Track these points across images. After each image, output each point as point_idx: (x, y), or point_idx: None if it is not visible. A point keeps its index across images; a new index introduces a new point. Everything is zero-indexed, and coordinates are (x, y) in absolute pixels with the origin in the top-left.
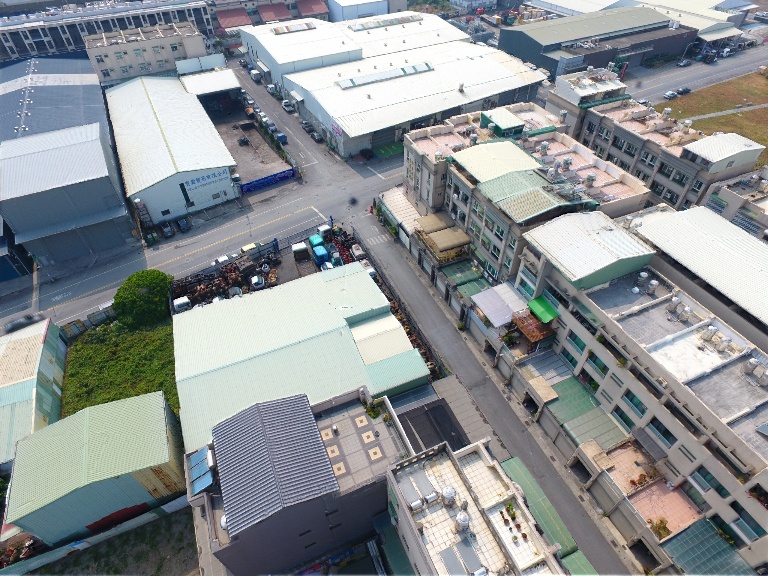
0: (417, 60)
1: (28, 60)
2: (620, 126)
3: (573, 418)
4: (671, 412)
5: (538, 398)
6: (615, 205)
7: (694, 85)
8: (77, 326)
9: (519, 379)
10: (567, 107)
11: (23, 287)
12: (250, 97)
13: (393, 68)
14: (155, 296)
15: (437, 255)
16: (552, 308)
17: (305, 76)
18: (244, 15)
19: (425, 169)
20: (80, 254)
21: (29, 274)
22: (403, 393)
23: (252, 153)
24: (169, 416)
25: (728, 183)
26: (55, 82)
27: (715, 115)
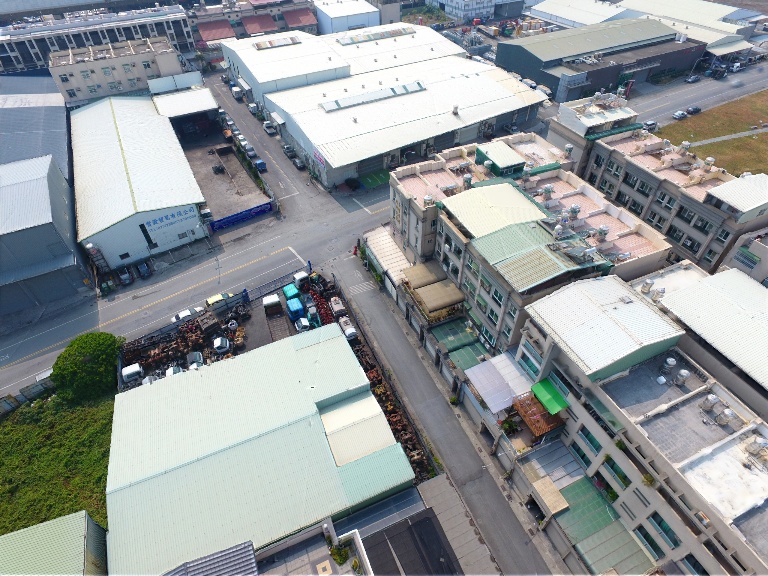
0: (409, 78)
1: None
2: (632, 162)
3: (587, 536)
4: (714, 555)
5: (544, 507)
6: (632, 264)
7: (704, 104)
8: (8, 402)
9: (521, 477)
10: (572, 137)
11: None
12: (229, 117)
13: (382, 87)
14: (100, 366)
15: (426, 314)
16: (560, 395)
17: (287, 96)
18: (227, 27)
19: (413, 214)
20: (24, 307)
21: None
22: (383, 500)
23: (227, 182)
24: (95, 539)
25: (759, 233)
26: (15, 104)
27: (729, 138)
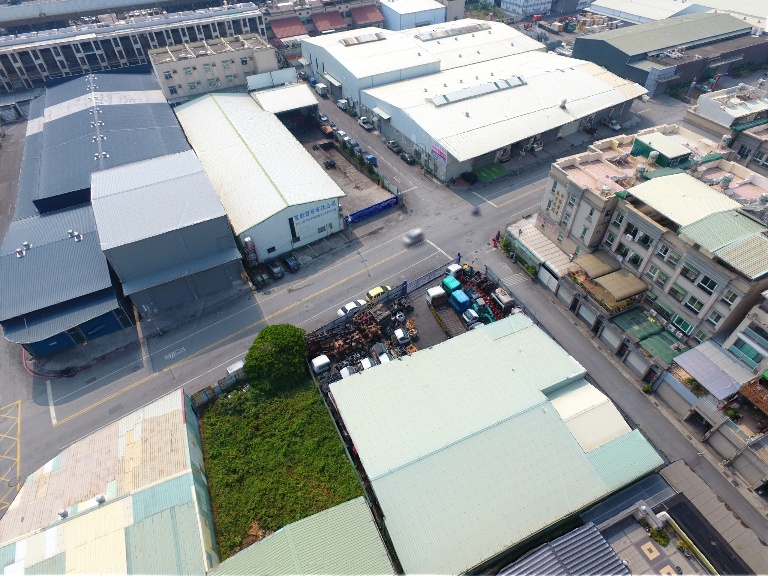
0: (503, 73)
1: (86, 76)
2: None
3: None
4: None
5: None
6: None
7: None
8: (207, 393)
9: (753, 463)
10: (713, 129)
11: (128, 342)
12: (323, 113)
13: (481, 82)
14: (294, 357)
15: (606, 304)
16: None
17: (387, 91)
18: (299, 24)
19: (586, 205)
20: (184, 300)
21: (132, 326)
22: (630, 486)
23: (342, 177)
24: None
25: None
26: (121, 100)
27: None
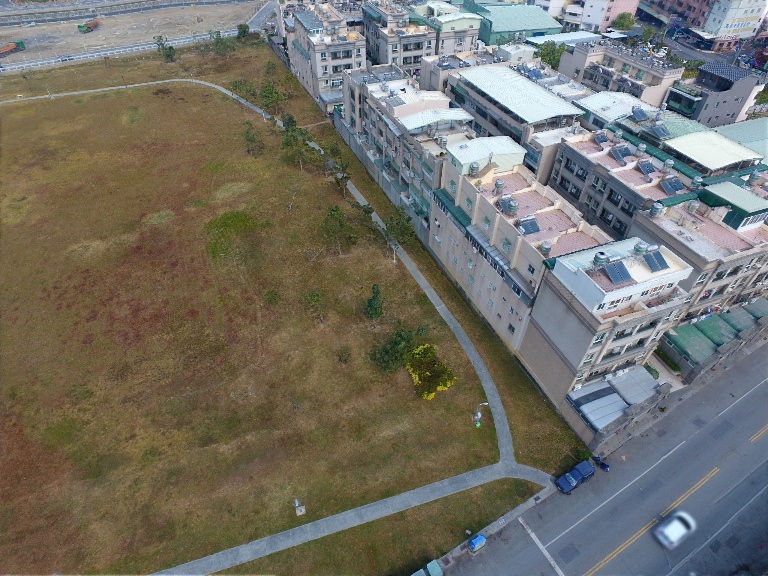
0: None
1: None
2: None
3: None
4: None
5: None
6: None
7: None
8: None
9: None
10: None
11: None
12: None
13: None
14: None
15: None
16: None
17: None
18: None
19: None
20: None
21: None
22: None
23: None
24: None
25: None
26: None
27: None
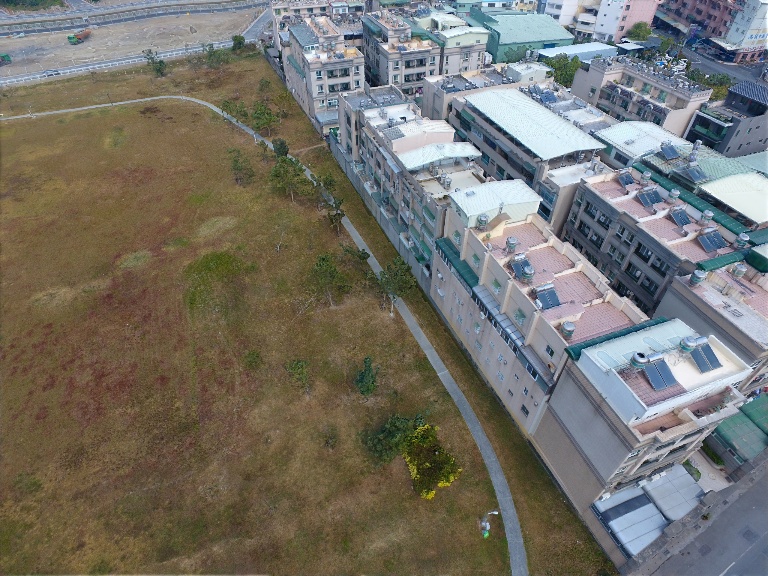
0: None
1: None
2: None
3: None
4: None
5: None
6: None
7: None
8: None
9: None
10: None
11: None
12: None
13: None
14: None
15: None
16: None
17: None
18: None
19: None
20: None
21: None
22: None
23: None
24: None
25: None
26: None
27: None
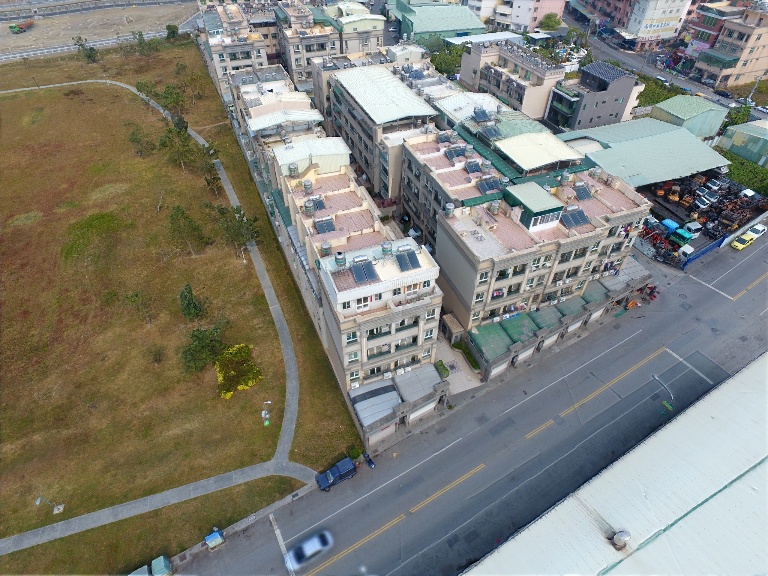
0: None
1: None
2: None
3: None
4: None
5: None
6: None
7: None
8: None
9: None
10: None
11: None
12: None
13: None
14: None
15: None
16: None
17: None
18: None
19: None
20: None
21: None
22: None
23: None
24: None
25: None
26: None
27: None
